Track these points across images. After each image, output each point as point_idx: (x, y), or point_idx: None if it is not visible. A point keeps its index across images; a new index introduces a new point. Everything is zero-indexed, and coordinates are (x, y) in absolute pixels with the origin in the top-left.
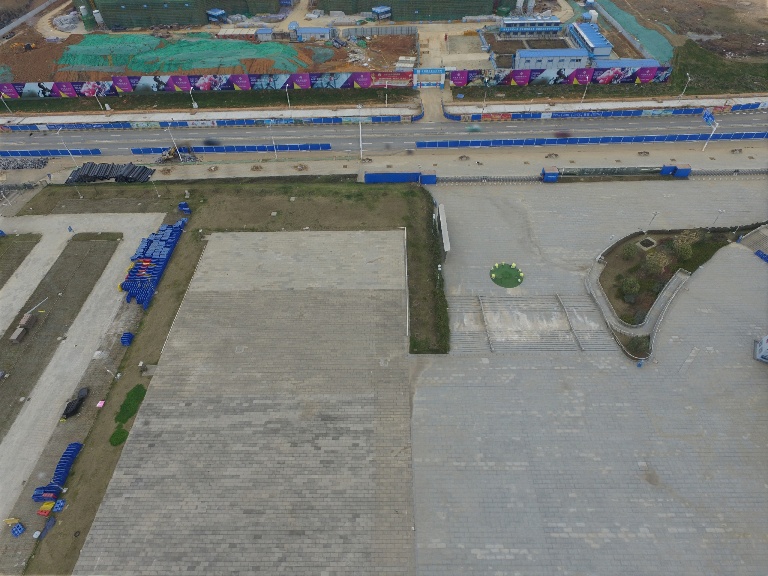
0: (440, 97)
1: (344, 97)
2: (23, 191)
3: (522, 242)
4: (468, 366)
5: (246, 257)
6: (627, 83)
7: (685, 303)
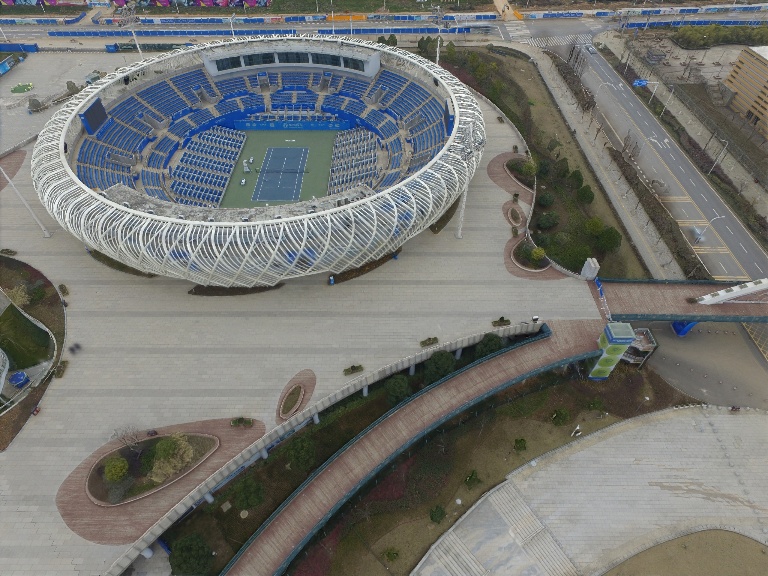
0: (103, 12)
1: (36, 11)
2: None
3: (53, 76)
4: None
5: None
6: (239, 6)
7: None
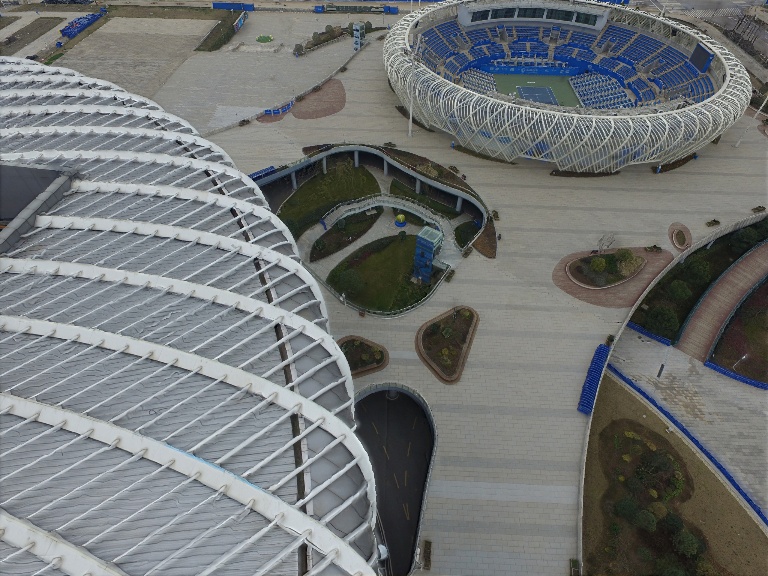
0: None
1: None
2: (13, 5)
3: (283, 31)
4: (218, 54)
5: (129, 24)
6: None
7: (339, 44)
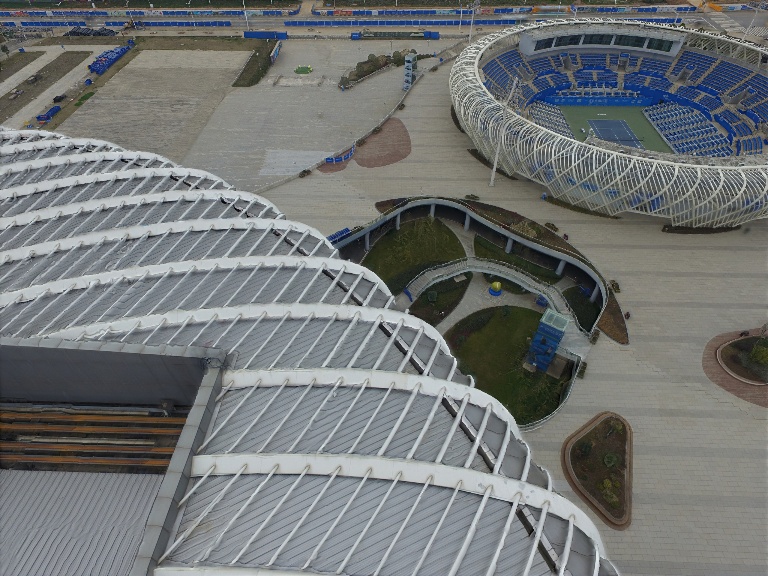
0: None
1: (251, 4)
2: (36, 39)
3: (321, 60)
4: (258, 90)
5: (160, 58)
6: None
7: (385, 75)
